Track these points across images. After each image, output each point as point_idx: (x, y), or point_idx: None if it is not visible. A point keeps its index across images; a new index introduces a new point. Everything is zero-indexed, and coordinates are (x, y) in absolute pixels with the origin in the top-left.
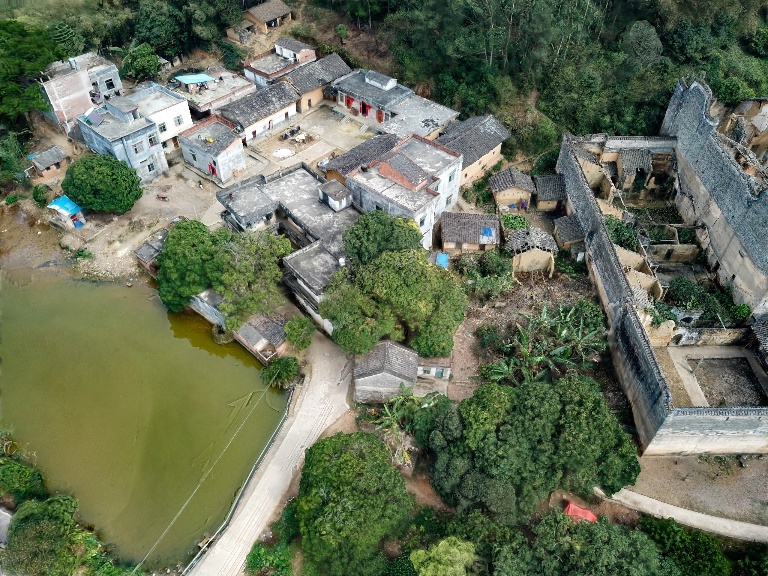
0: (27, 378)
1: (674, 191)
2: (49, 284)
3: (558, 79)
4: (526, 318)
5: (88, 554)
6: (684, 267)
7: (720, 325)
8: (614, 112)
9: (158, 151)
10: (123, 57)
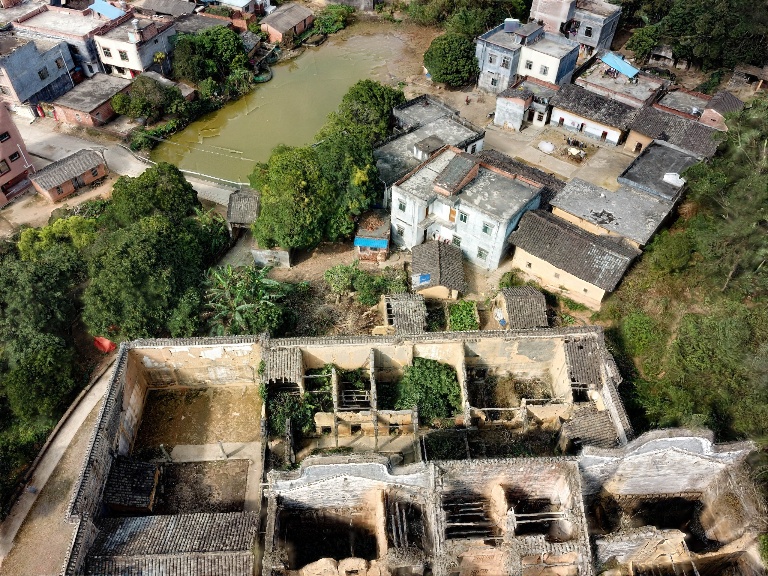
0: (293, 92)
1: None
2: None
3: None
4: None
5: (162, 127)
6: None
7: None
8: (708, 407)
9: (505, 74)
10: (639, 28)
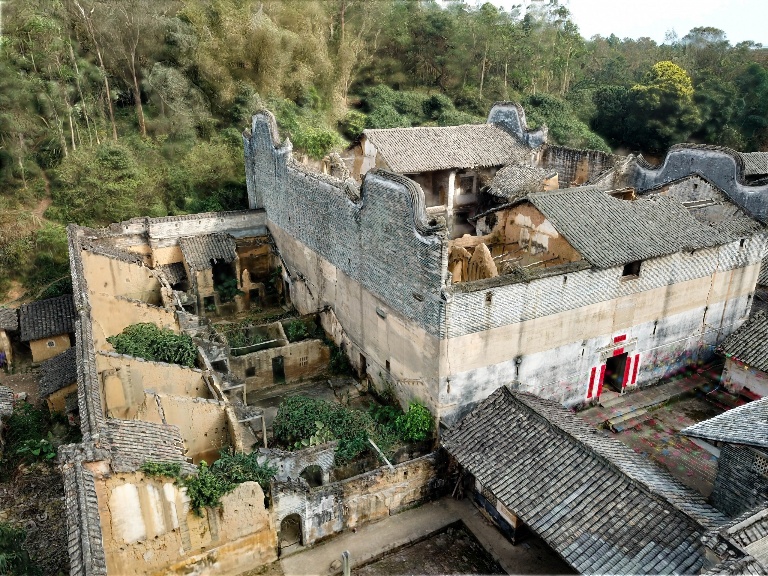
0: None
1: (286, 287)
2: None
3: (65, 165)
4: None
5: None
6: (315, 386)
7: (379, 461)
8: None
9: None
10: None
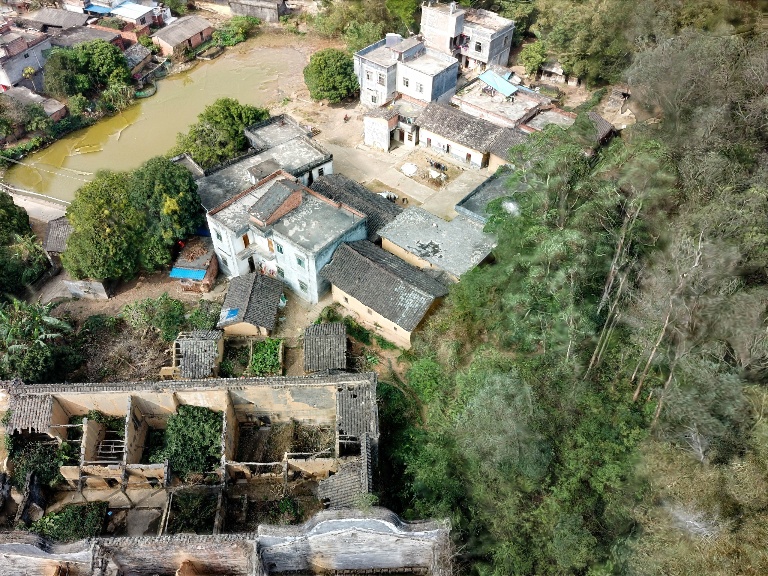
0: (173, 108)
1: None
2: (259, 97)
3: None
4: (50, 304)
5: (22, 145)
6: None
7: None
8: None
9: (382, 92)
10: None
